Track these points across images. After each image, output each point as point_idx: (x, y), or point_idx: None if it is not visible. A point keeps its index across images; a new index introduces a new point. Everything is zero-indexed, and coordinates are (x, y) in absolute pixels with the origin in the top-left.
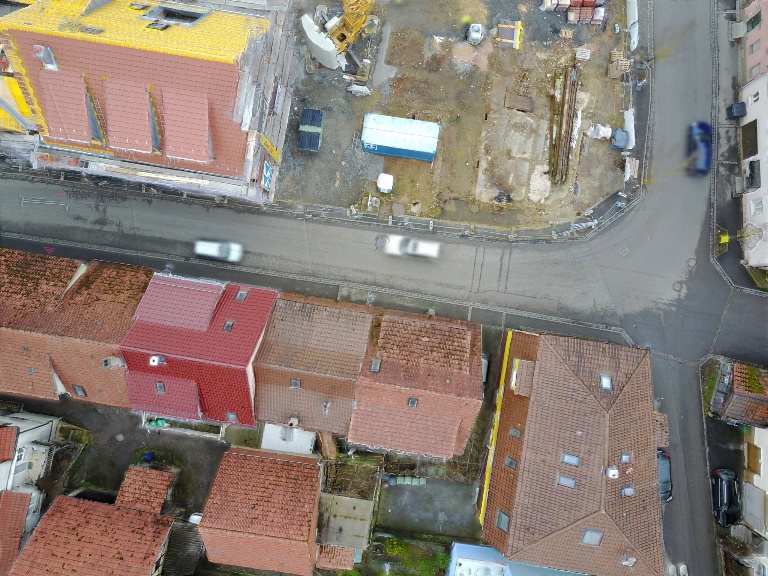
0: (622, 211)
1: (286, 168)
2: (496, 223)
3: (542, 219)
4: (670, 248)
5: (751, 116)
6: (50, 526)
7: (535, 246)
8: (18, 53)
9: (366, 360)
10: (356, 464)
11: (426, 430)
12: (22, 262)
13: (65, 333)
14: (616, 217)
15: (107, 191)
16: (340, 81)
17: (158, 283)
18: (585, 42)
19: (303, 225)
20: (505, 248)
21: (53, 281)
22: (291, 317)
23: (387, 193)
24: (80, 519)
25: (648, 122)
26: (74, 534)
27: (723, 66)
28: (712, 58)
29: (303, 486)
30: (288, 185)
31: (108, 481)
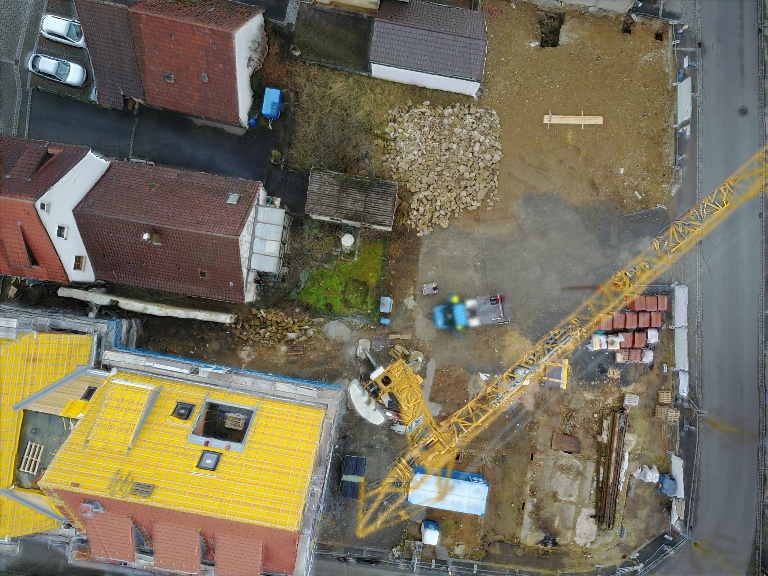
0: (668, 553)
1: (326, 508)
2: (541, 566)
3: (587, 562)
4: None
5: None
6: None
7: None
8: (62, 499)
9: None
10: None
11: None
12: None
13: None
14: (662, 559)
15: None
16: None
17: None
18: (633, 382)
19: (343, 568)
20: None
21: None
22: None
23: None
24: None
25: (695, 462)
26: None
27: None
28: (759, 398)
29: None
30: (328, 526)
31: None
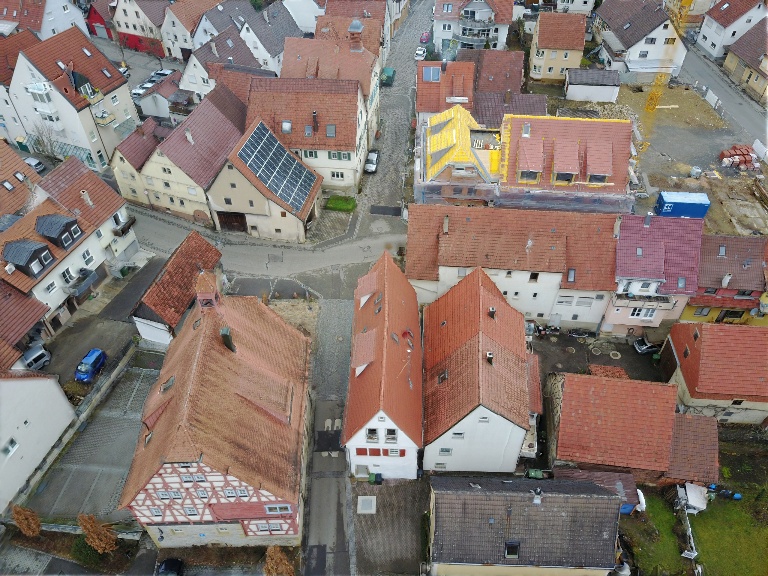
0: None
1: None
2: None
3: None
4: None
5: None
6: None
7: None
8: (511, 130)
9: None
10: None
11: None
12: None
13: None
14: None
15: None
16: None
17: None
18: None
19: None
20: None
21: None
22: None
23: None
24: None
25: None
26: None
27: None
28: None
29: None
30: None
31: None
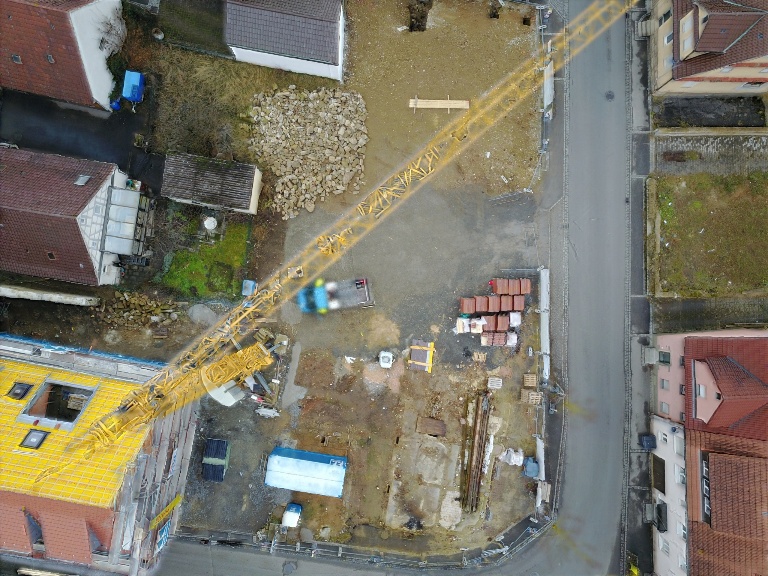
0: (533, 536)
1: (191, 491)
2: (406, 549)
3: (453, 545)
4: (581, 573)
5: (660, 453)
6: None
7: (445, 572)
8: None
9: None
10: None
11: None
12: None
13: None
14: (527, 542)
15: None
16: (248, 401)
17: None
18: (498, 365)
19: (208, 551)
20: (415, 574)
21: None
22: None
23: None
24: None
25: (561, 445)
26: None
27: (636, 390)
28: (625, 381)
29: None
30: (193, 509)
31: None
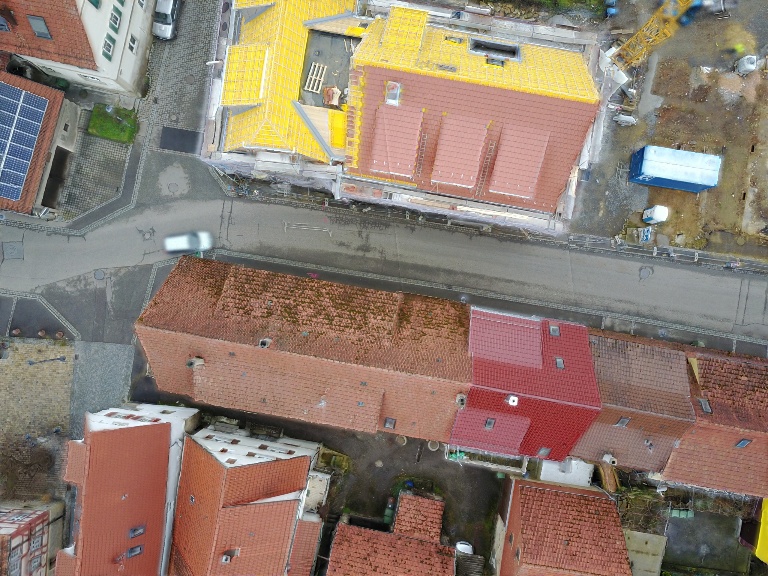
0: None
1: None
2: (761, 256)
3: None
4: None
5: None
6: (343, 556)
7: None
8: (363, 88)
9: (693, 399)
10: (648, 499)
11: (747, 470)
12: (343, 295)
13: (415, 371)
14: None
15: (370, 218)
16: None
17: (480, 318)
18: None
19: (567, 255)
20: None
21: (380, 315)
22: (607, 354)
23: (652, 224)
24: (368, 549)
25: None
26: (368, 564)
27: None
28: None
29: (607, 522)
30: None
31: (367, 507)
